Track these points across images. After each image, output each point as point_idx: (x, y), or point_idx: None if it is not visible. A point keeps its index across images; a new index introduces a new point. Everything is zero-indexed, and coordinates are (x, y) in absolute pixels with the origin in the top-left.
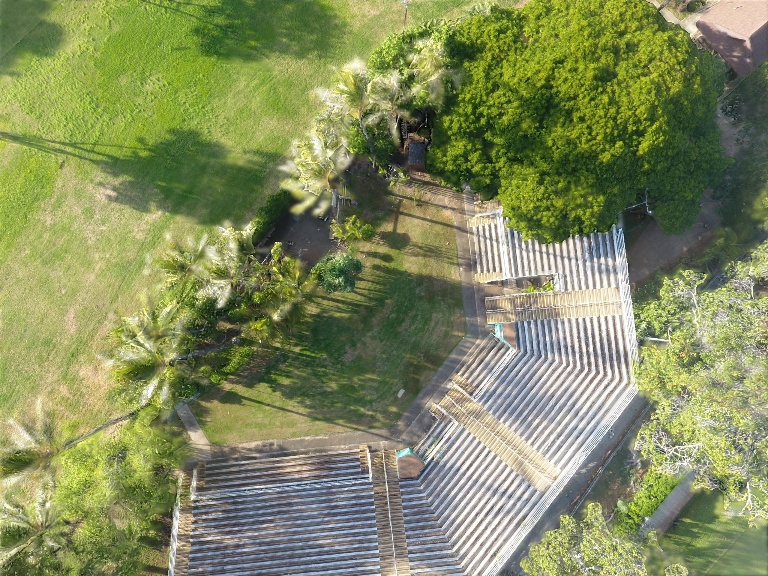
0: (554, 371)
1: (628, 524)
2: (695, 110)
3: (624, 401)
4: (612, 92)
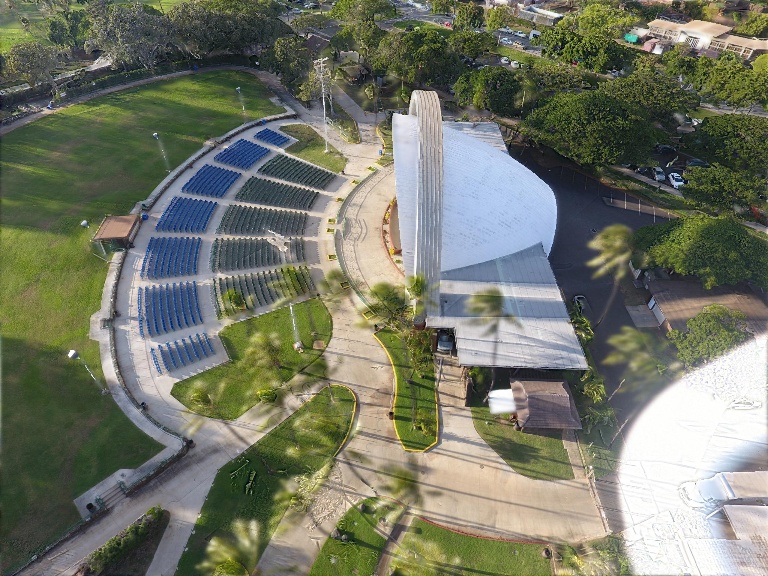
0: None
1: None
2: None
3: (104, 65)
4: None
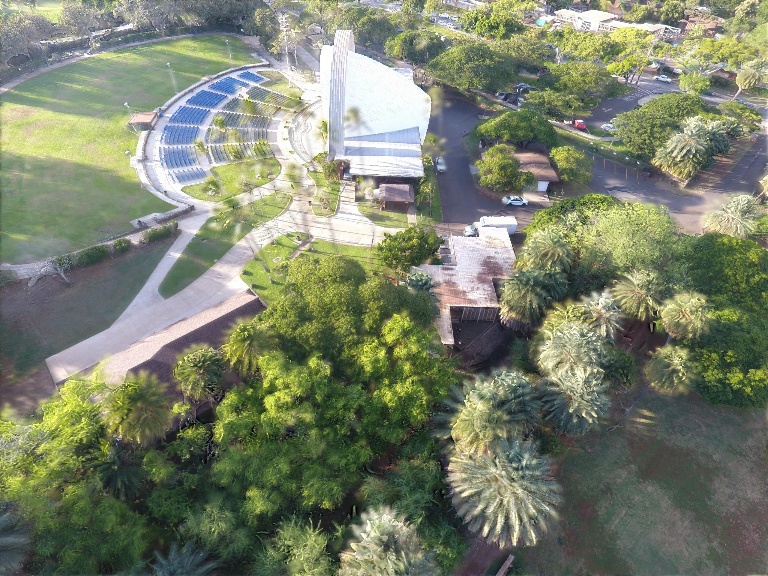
0: None
1: None
2: None
3: (126, 28)
4: None
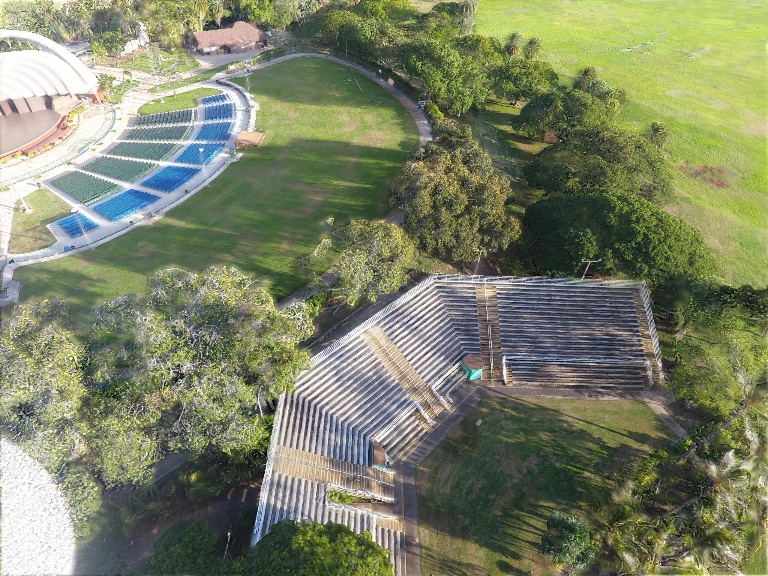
0: (344, 413)
1: (319, 299)
2: None
3: None
4: None
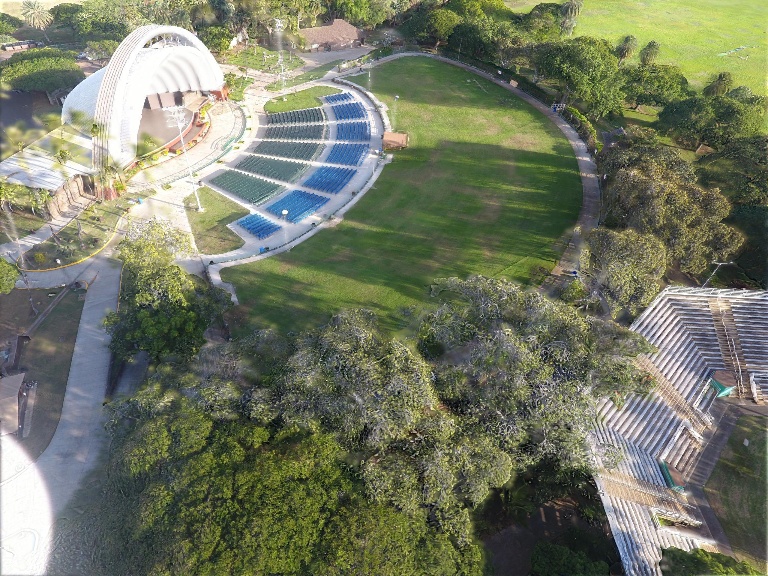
0: (626, 431)
1: None
2: None
3: None
4: None
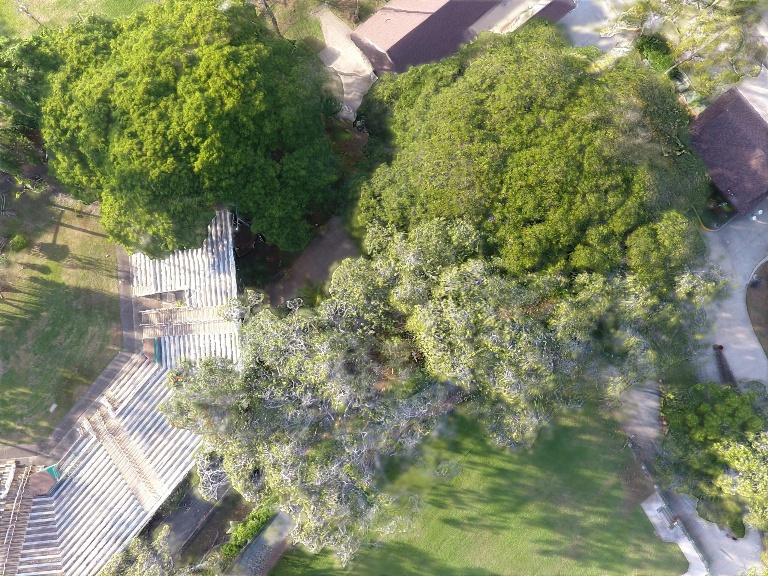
0: None
1: (228, 546)
2: (264, 126)
3: None
4: (166, 107)
